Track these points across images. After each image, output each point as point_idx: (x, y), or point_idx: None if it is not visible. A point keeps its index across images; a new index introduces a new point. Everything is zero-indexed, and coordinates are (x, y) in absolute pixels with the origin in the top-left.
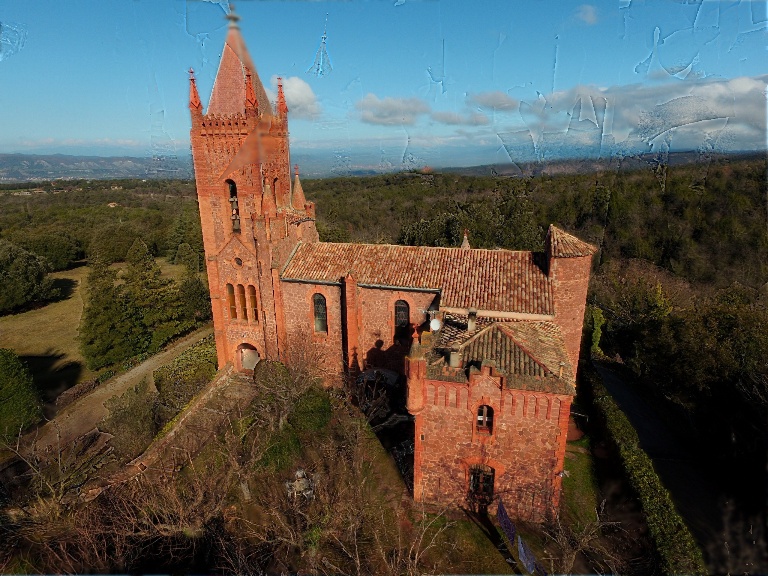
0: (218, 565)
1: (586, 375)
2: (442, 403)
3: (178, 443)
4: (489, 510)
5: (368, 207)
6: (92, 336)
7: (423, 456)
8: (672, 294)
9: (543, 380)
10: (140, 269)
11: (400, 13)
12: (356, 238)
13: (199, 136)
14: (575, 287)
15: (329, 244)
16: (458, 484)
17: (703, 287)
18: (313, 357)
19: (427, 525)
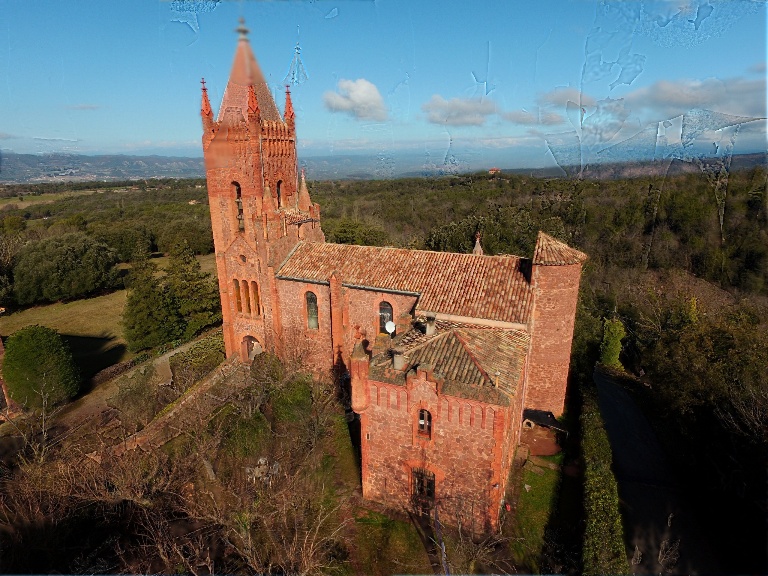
0: (137, 532)
1: (581, 389)
2: (384, 404)
3: (176, 423)
4: (432, 515)
5: (412, 209)
6: (132, 322)
7: (369, 455)
8: (714, 309)
9: (478, 388)
10: (180, 262)
11: (374, 21)
12: (391, 239)
13: (209, 141)
14: (559, 296)
15: (327, 245)
16: (402, 486)
17: (761, 304)
18: (306, 352)
19: (323, 518)
